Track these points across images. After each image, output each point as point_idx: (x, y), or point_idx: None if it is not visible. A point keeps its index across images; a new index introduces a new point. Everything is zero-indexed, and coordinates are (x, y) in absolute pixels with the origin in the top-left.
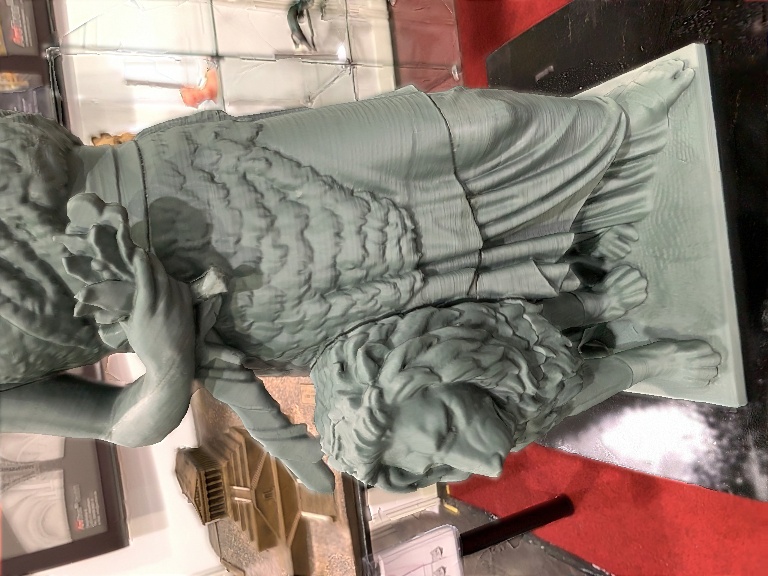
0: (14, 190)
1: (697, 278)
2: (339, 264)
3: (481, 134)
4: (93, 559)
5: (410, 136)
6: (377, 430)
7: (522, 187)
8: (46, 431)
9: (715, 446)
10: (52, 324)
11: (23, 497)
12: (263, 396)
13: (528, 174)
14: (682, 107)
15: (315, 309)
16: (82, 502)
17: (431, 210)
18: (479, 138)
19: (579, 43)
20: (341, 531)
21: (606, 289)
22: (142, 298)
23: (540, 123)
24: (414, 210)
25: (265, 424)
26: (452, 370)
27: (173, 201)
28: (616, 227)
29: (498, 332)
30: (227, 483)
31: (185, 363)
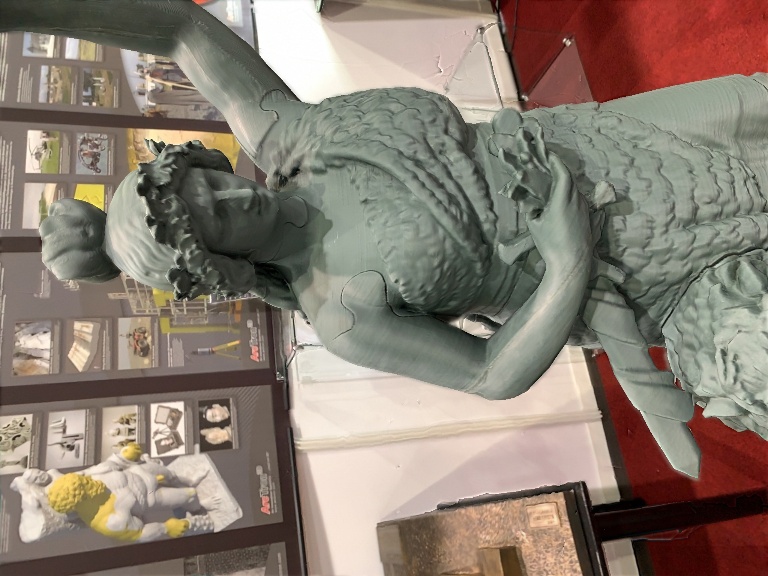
0: (440, 124)
1: None
2: (697, 198)
3: None
4: None
5: (736, 97)
6: None
7: None
8: (431, 365)
9: None
10: (467, 231)
11: None
12: (637, 329)
13: None
14: None
15: (682, 237)
16: None
17: (762, 166)
18: None
19: None
20: None
21: None
22: (563, 183)
23: None
24: (747, 165)
25: (637, 364)
26: None
27: (548, 144)
28: None
29: None
30: None
31: (589, 259)
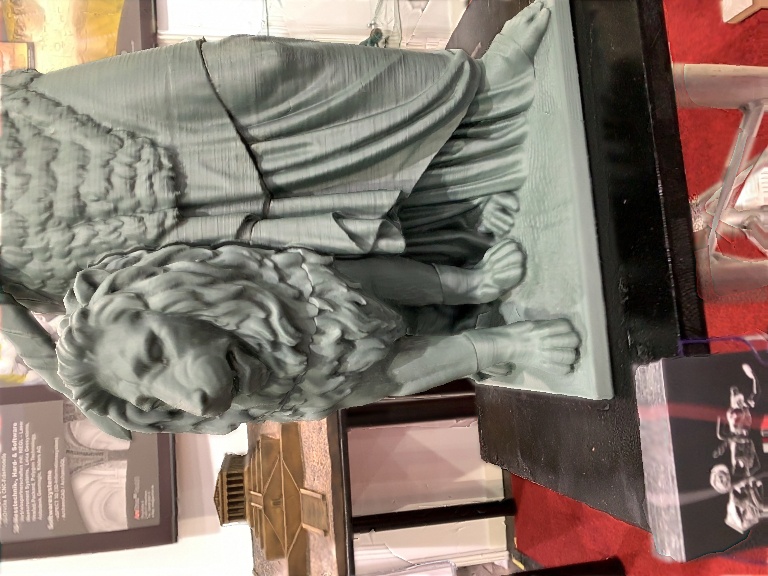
0: None
1: (560, 245)
2: (83, 195)
3: (244, 74)
4: (144, 549)
5: (163, 76)
6: (71, 348)
7: (317, 134)
8: None
9: (593, 453)
10: None
11: (91, 481)
12: (21, 321)
13: (333, 123)
14: (544, 53)
15: (57, 237)
16: (140, 493)
17: (199, 152)
18: (242, 78)
19: (494, 12)
20: (330, 547)
21: (483, 265)
22: None
23: (338, 68)
24: (179, 151)
25: (31, 351)
26: (159, 298)
27: None
28: (495, 196)
29: (262, 278)
30: (247, 487)
31: None
